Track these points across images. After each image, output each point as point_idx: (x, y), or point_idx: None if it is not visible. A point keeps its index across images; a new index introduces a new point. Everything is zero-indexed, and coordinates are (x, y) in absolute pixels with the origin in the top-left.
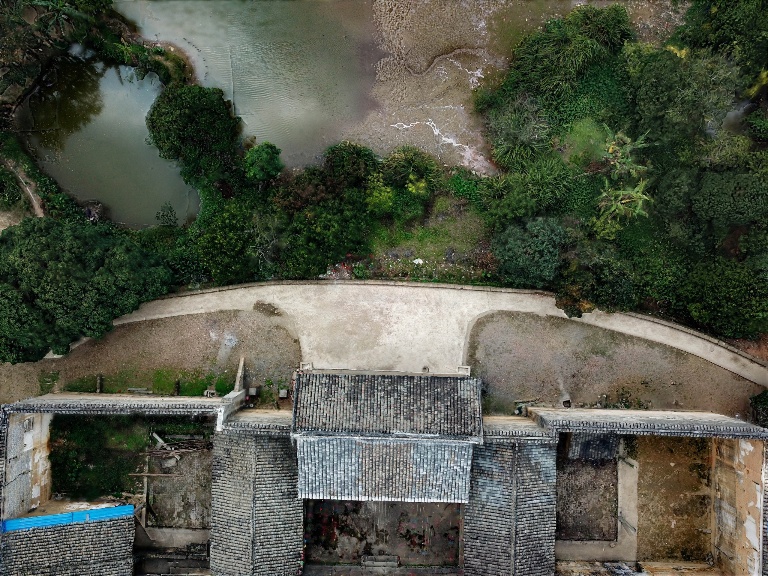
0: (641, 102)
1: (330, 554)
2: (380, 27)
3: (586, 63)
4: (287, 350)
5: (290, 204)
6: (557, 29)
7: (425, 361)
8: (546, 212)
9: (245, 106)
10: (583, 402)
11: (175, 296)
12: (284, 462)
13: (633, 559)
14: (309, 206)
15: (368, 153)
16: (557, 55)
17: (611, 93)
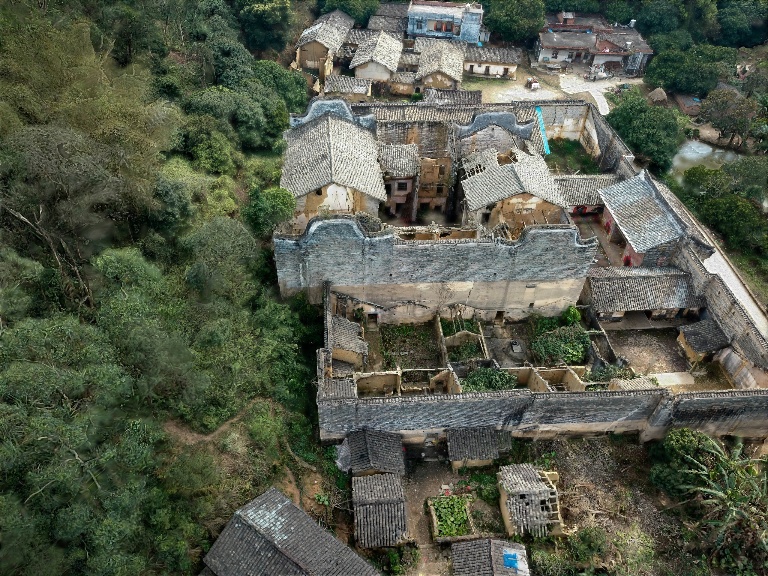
0: None
1: None
2: None
3: None
4: None
5: None
6: None
7: None
8: None
9: None
10: None
11: None
12: None
13: None
14: None
15: None
16: None
17: None
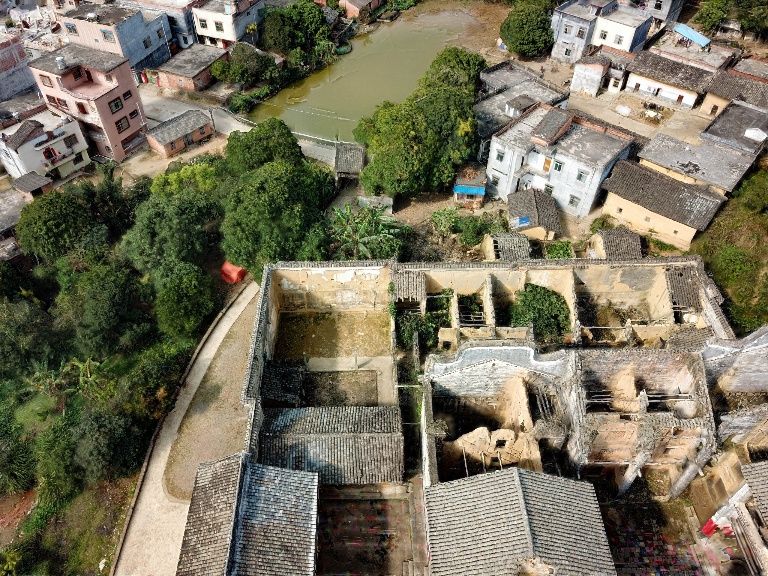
0: (7, 365)
1: None
2: None
3: None
4: None
5: None
6: None
7: None
8: None
9: None
10: None
11: None
12: None
13: (390, 359)
14: None
15: None
16: None
17: None
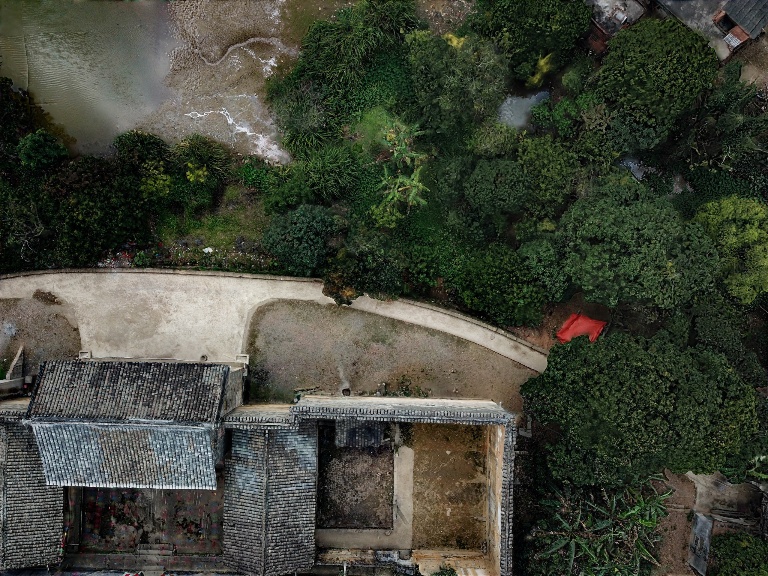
0: (415, 89)
1: (107, 542)
2: (174, 16)
3: (372, 51)
4: (67, 339)
5: (58, 192)
6: (346, 17)
7: (204, 349)
8: (333, 200)
9: (40, 95)
10: (363, 390)
11: None
12: None
13: (408, 547)
14: (73, 194)
15: (153, 142)
16: (337, 43)
17: (398, 81)
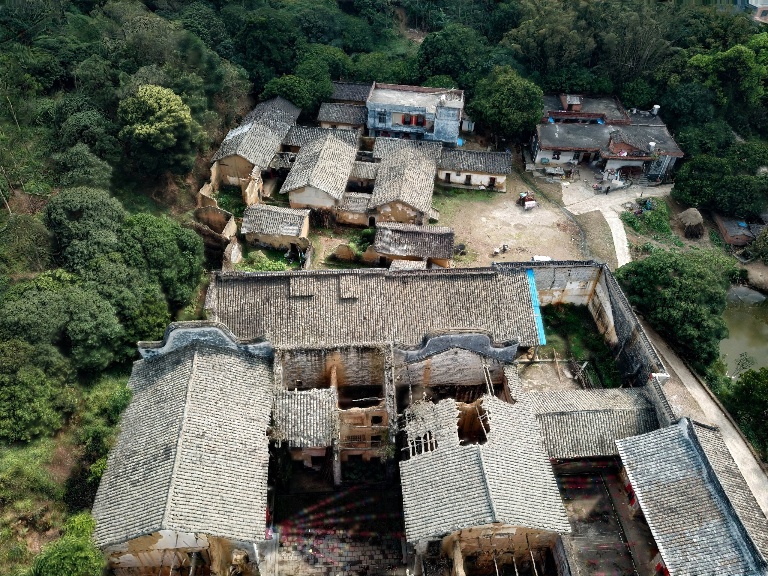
0: None
1: None
2: None
3: None
4: None
5: None
6: None
7: None
8: None
9: None
10: None
11: (692, 370)
12: (628, 435)
13: None
14: None
15: None
16: None
17: None
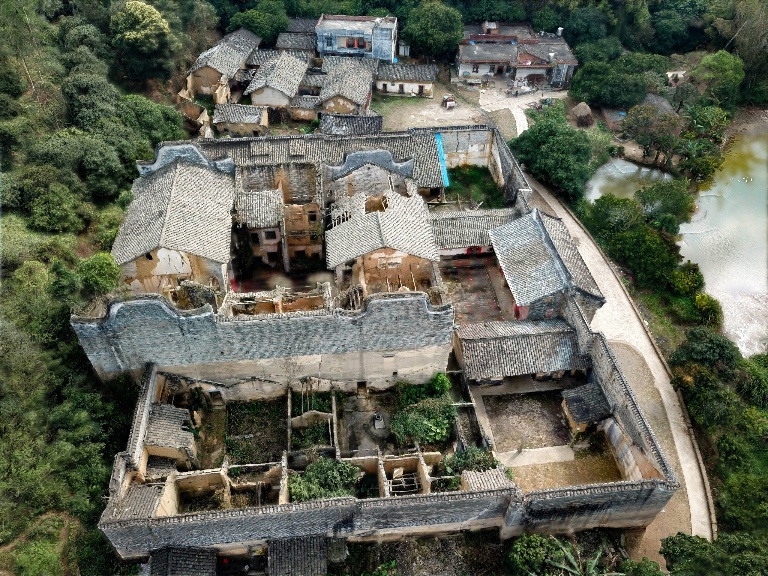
0: None
1: None
2: None
3: None
4: None
5: None
6: None
7: None
8: (735, 391)
9: (687, 239)
10: None
11: (564, 206)
12: None
13: None
14: None
15: (703, 283)
16: None
17: None
